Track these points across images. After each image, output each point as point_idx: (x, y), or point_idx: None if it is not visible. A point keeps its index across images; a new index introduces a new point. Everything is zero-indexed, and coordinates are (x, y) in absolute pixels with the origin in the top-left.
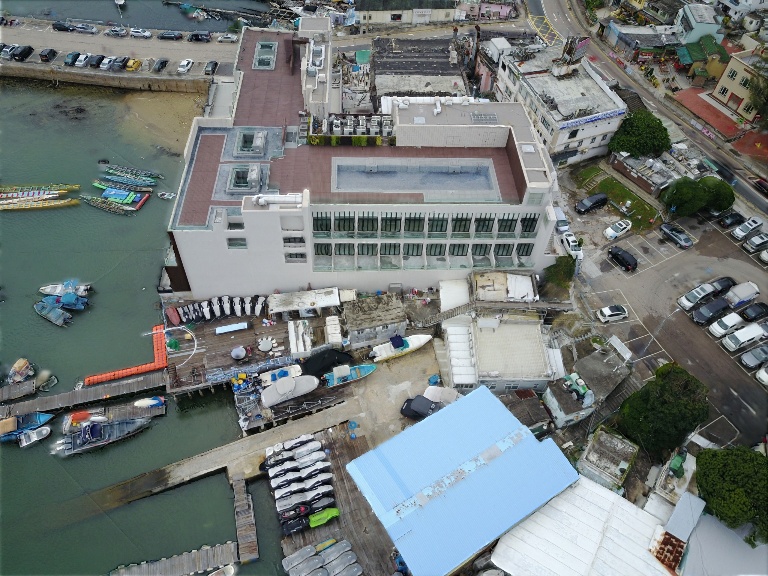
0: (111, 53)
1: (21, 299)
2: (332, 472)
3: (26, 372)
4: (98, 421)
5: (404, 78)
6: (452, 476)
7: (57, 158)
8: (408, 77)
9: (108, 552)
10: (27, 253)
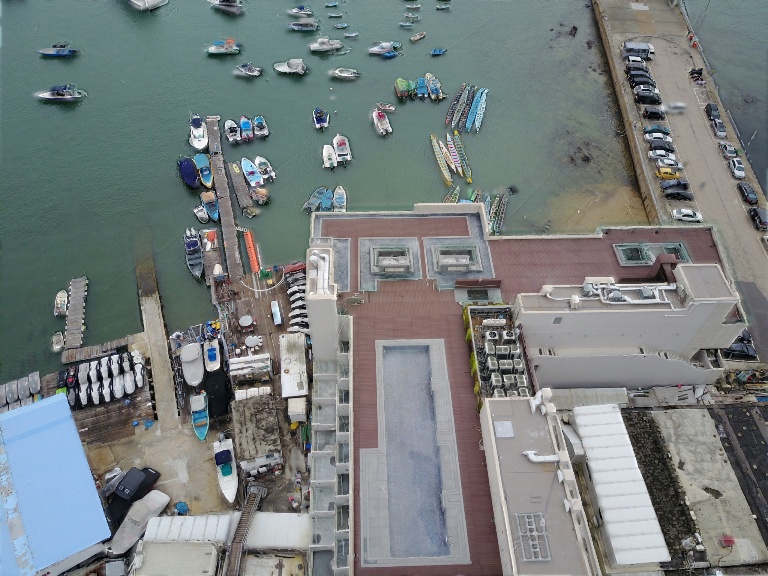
0: (685, 155)
1: (334, 180)
2: (106, 407)
3: (260, 199)
4: (206, 246)
5: (717, 453)
6: (8, 482)
7: (511, 162)
8: (723, 459)
9: (107, 275)
10: (384, 172)
